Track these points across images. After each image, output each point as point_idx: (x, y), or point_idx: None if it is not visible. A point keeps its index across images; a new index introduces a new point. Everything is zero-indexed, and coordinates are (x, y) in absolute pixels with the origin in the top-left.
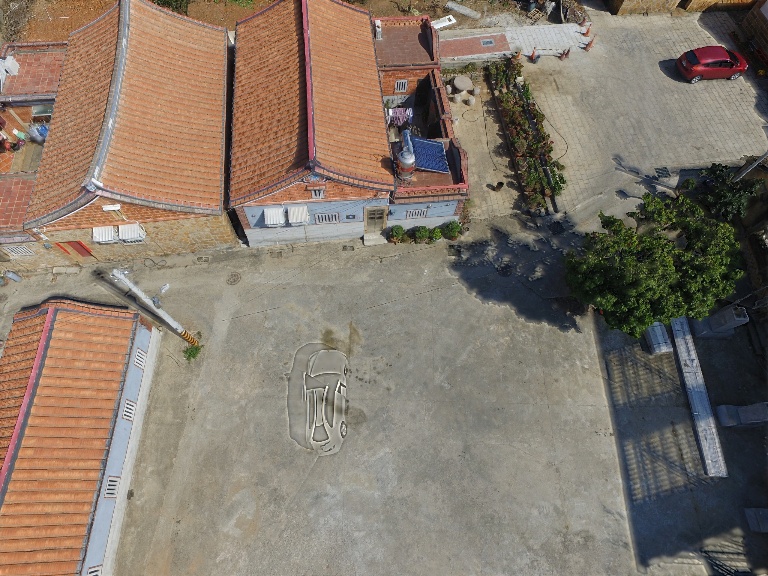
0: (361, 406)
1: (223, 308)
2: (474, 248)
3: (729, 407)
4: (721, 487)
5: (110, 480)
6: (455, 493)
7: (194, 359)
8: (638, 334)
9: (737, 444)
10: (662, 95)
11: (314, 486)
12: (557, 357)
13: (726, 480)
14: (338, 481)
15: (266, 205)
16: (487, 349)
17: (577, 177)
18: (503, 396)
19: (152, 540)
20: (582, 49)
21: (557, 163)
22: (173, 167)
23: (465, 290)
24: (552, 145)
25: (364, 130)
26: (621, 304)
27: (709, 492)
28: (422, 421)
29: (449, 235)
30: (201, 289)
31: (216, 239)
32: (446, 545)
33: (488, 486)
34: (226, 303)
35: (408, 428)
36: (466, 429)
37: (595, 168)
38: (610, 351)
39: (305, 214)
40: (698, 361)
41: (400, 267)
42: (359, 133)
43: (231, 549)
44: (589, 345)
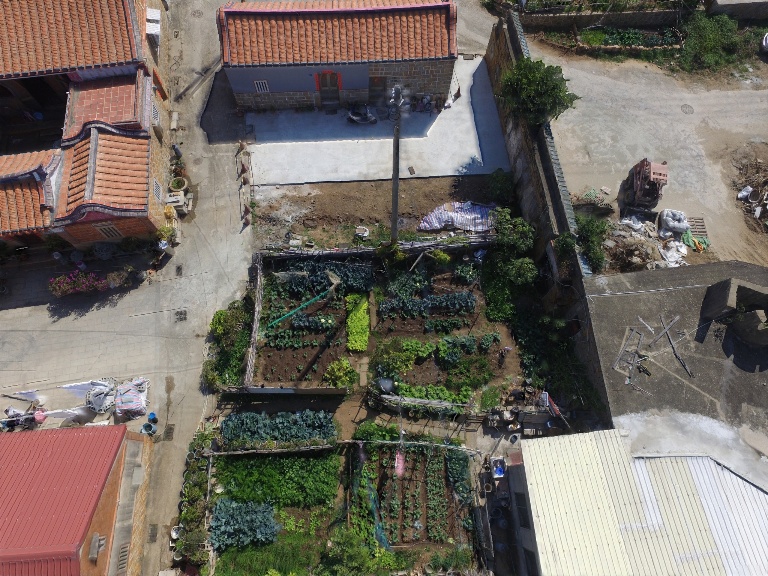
0: None
1: None
2: None
3: None
4: None
5: None
6: None
7: None
8: None
9: None
10: None
11: None
12: None
13: None
14: None
15: None
16: None
17: None
18: None
19: None
20: None
21: None
22: None
23: None
24: None
25: None
26: None
27: None
28: None
29: None
30: (204, 31)
31: (161, 8)
32: None
33: None
34: None
35: None
36: None
37: None
38: None
39: None
40: None
41: None
42: None
43: None
44: None
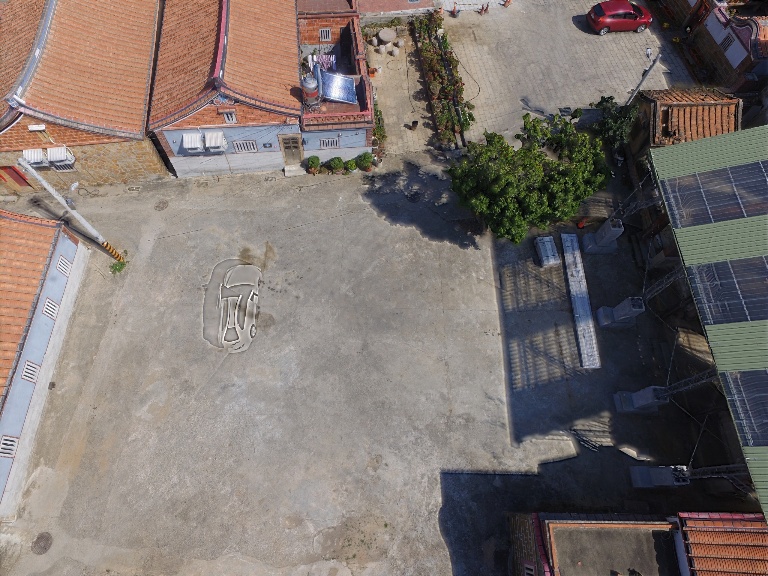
0: (271, 312)
1: (149, 230)
2: (387, 178)
3: (605, 308)
4: (594, 377)
5: (28, 365)
6: (351, 383)
7: (119, 273)
8: (518, 239)
9: (613, 342)
10: (572, 45)
11: (222, 378)
12: (455, 270)
13: (599, 371)
14: (245, 374)
15: (184, 129)
16: (391, 263)
17: (486, 116)
18: (402, 303)
19: (70, 423)
20: (502, 5)
21: (468, 103)
22: (98, 95)
23: (375, 214)
24: (465, 88)
25: (277, 63)
26: (494, 205)
27: (583, 381)
28: (326, 324)
29: (362, 165)
30: (130, 214)
31: (144, 168)
32: (339, 426)
33: (382, 377)
34: (153, 226)
35: (312, 330)
36: (366, 330)
37: (503, 108)
38: (504, 265)
39: (221, 139)
40: (583, 272)
41: (317, 195)
42: (271, 65)
43: (142, 431)
44: (486, 260)
